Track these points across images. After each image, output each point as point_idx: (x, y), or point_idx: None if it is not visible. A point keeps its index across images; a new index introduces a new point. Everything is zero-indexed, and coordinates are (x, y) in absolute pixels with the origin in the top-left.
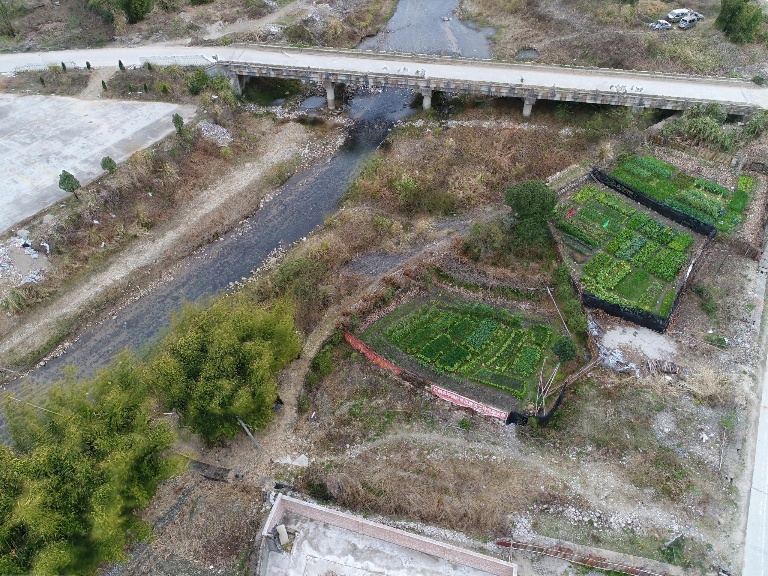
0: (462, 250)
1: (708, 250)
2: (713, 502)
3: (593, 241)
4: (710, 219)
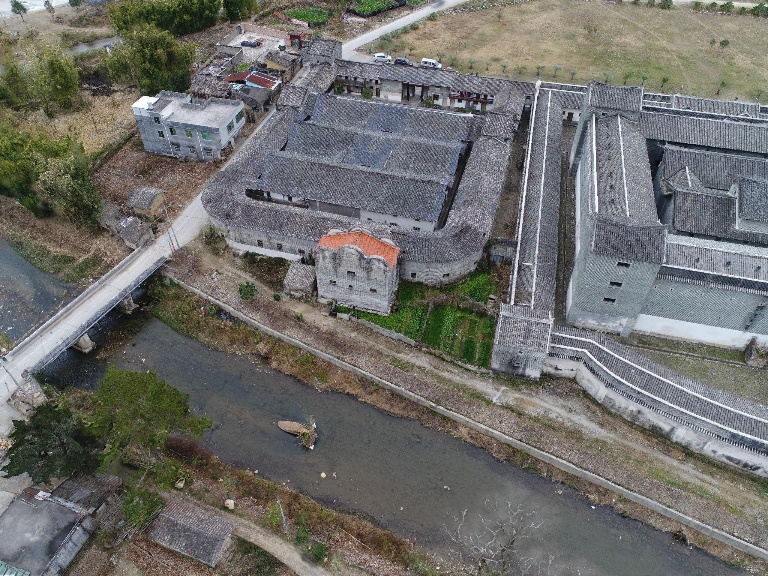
0: (320, 1)
1: (401, 7)
2: (348, 37)
3: (364, 3)
4: (409, 2)
